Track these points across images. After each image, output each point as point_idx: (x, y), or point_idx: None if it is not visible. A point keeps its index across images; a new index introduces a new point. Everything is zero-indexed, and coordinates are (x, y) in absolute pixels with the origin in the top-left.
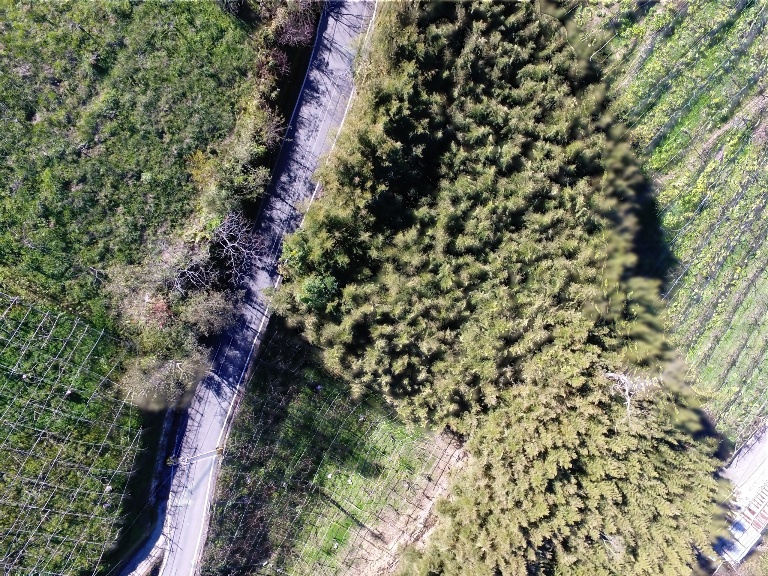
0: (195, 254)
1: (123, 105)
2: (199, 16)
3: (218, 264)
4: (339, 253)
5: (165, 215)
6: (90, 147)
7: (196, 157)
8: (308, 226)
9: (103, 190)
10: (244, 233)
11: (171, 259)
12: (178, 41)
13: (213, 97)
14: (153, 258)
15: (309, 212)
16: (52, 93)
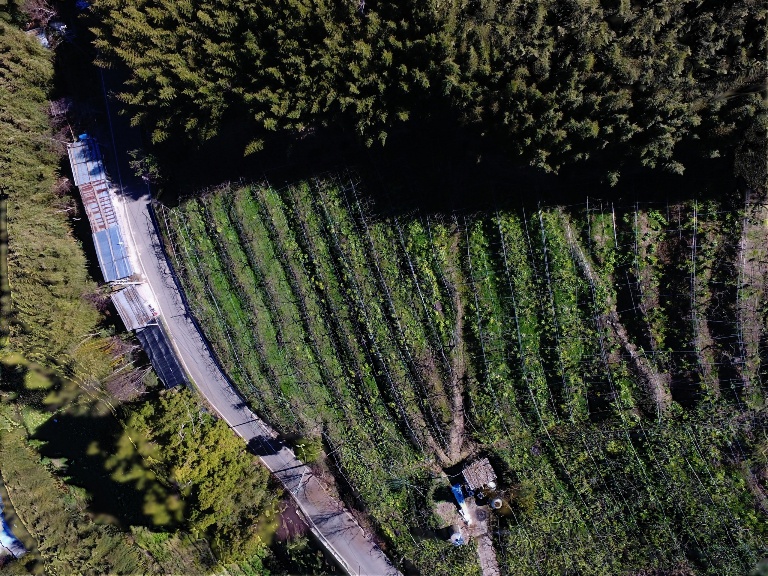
0: None
1: None
2: None
3: None
4: None
5: None
6: None
7: None
8: None
9: None
10: None
11: None
12: None
13: None
14: None
15: None
16: None
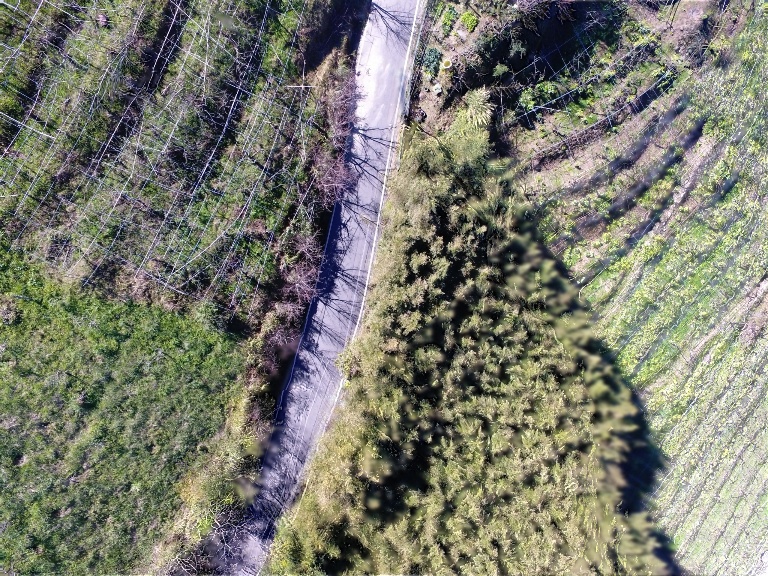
0: (186, 539)
1: (111, 431)
2: (187, 339)
3: (209, 548)
4: (330, 545)
5: (155, 511)
6: (78, 474)
7: (186, 458)
8: (299, 525)
9: (92, 507)
10: (235, 510)
11: (162, 559)
12: (166, 363)
13: (202, 404)
14: (144, 558)
15: (300, 511)
16: (39, 436)
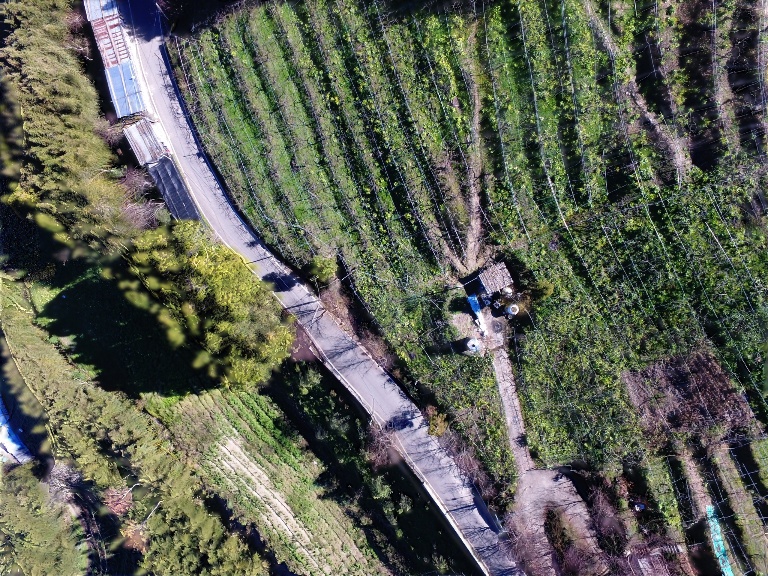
0: None
1: None
2: None
3: None
4: None
5: None
6: None
7: None
8: None
9: None
10: None
11: None
12: None
13: None
14: None
15: None
16: None
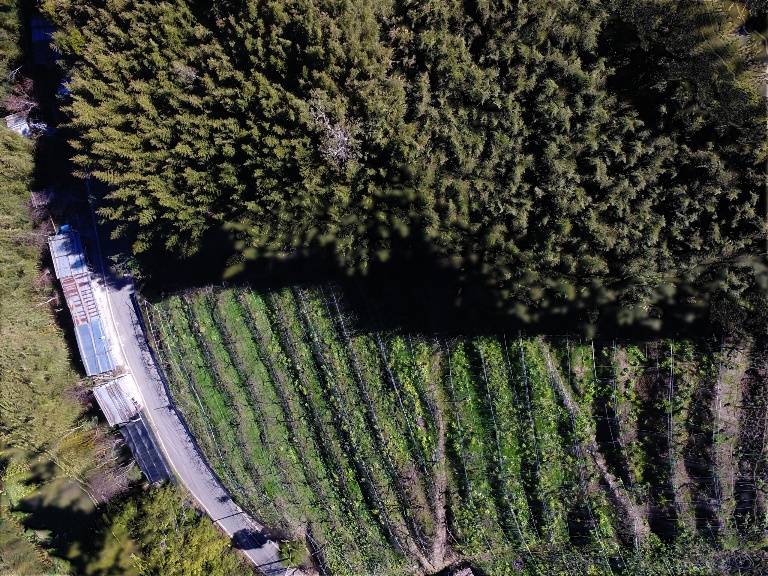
0: None
1: None
2: None
3: None
4: None
5: None
6: None
7: None
8: None
9: None
10: None
11: None
12: None
13: None
14: None
15: None
16: None
